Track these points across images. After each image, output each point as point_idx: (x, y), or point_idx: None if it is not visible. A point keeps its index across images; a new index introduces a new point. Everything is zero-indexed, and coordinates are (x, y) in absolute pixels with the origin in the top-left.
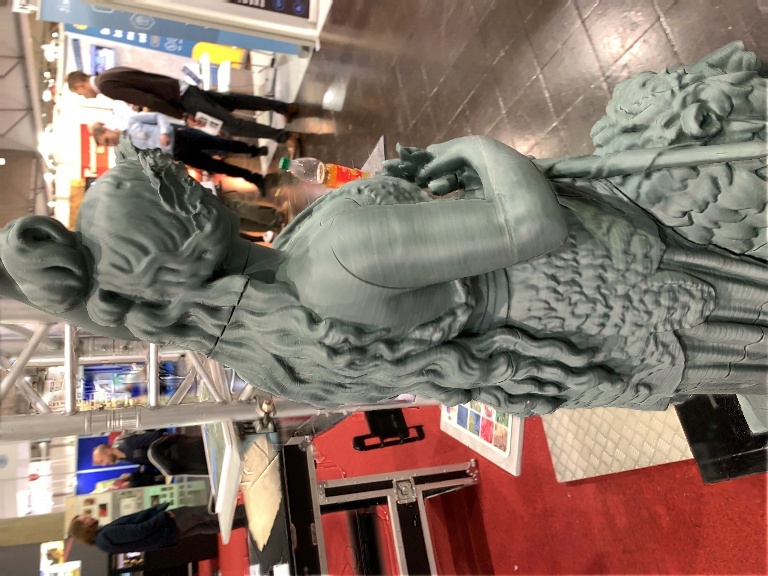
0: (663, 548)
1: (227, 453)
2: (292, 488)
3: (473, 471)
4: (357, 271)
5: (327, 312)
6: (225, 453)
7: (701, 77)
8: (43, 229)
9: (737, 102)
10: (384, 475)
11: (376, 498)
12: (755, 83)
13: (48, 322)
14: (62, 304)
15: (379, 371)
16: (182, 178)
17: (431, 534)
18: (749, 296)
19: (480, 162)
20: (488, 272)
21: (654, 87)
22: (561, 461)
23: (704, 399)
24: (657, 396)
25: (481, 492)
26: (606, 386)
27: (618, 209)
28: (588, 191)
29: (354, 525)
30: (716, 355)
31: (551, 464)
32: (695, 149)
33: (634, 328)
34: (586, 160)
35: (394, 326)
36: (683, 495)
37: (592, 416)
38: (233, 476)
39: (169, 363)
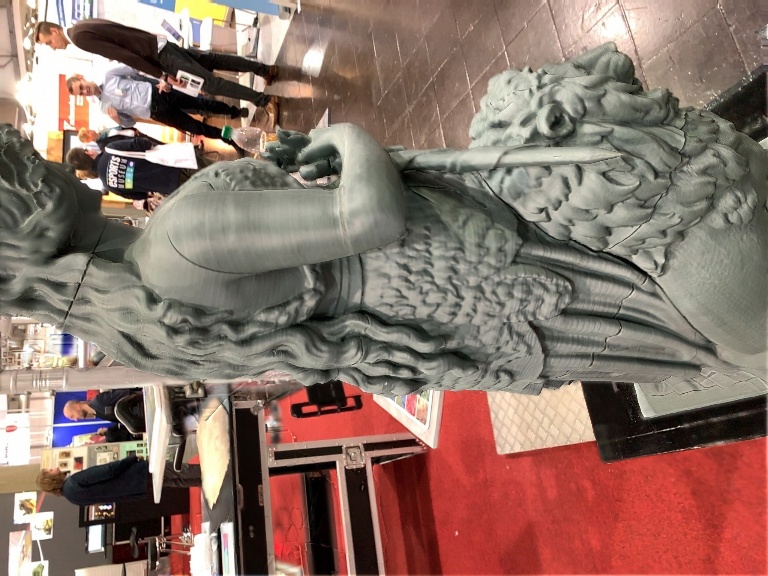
0: (587, 520)
1: (157, 416)
2: (242, 450)
3: None
4: (190, 255)
5: (166, 293)
6: (155, 416)
7: (559, 78)
8: None
9: (590, 105)
10: (334, 441)
11: (325, 463)
12: (609, 87)
13: None
14: None
15: (224, 350)
16: (25, 156)
17: (377, 499)
18: (608, 291)
19: (342, 151)
20: (343, 259)
21: (516, 85)
22: (502, 434)
23: (608, 383)
24: (523, 382)
25: (429, 460)
26: (458, 372)
27: (480, 202)
28: (454, 183)
29: (301, 488)
30: (576, 346)
31: (493, 437)
32: (536, 150)
33: (486, 318)
34: (444, 154)
35: (237, 308)
36: (608, 471)
37: None
38: (162, 438)
39: None
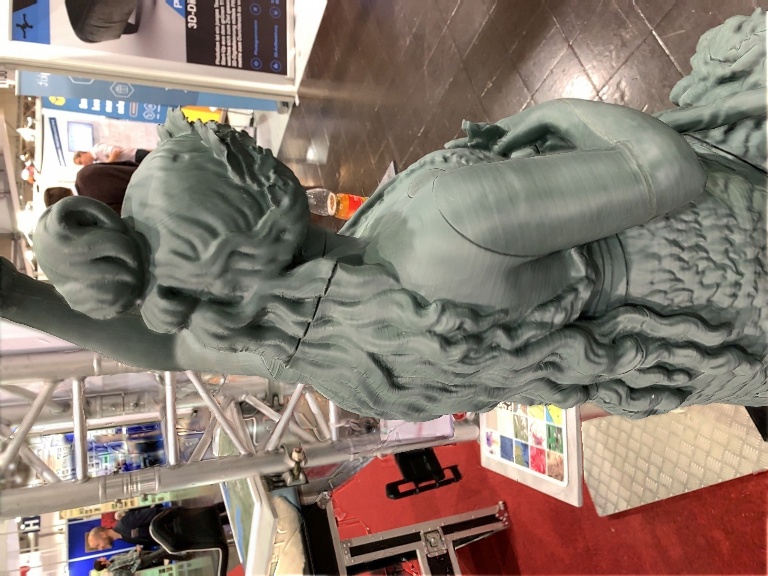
0: None
1: (256, 512)
2: (314, 550)
3: (502, 514)
4: (474, 236)
5: (436, 293)
6: (254, 512)
7: None
8: (88, 212)
9: None
10: (410, 527)
11: (404, 553)
12: None
13: (54, 379)
14: (113, 306)
15: (497, 364)
16: (249, 146)
17: None
18: None
19: (573, 122)
20: (600, 243)
21: (754, 27)
22: (600, 493)
23: None
24: None
25: (513, 537)
26: (744, 368)
27: (727, 166)
28: None
29: None
30: None
31: (589, 498)
32: None
33: (767, 297)
34: (694, 109)
35: (512, 307)
36: (742, 516)
37: (629, 441)
38: (265, 537)
39: (181, 420)
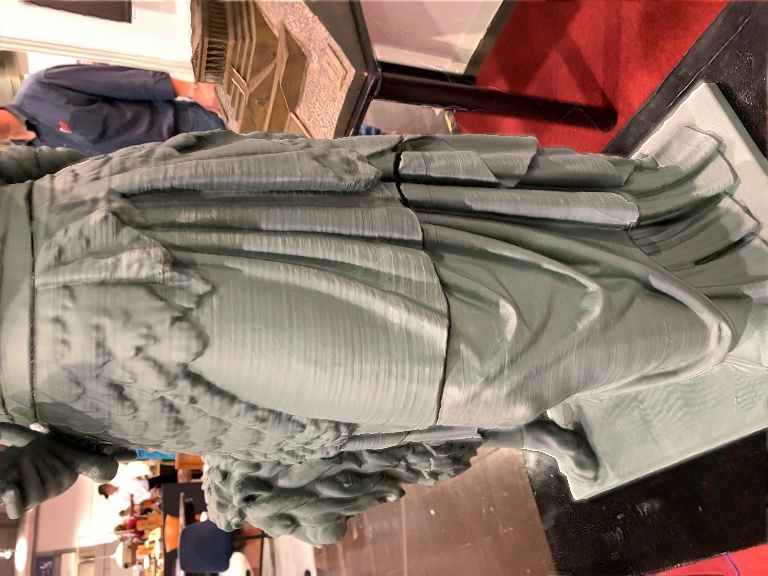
0: None
1: None
2: None
3: None
4: None
5: None
6: None
7: None
8: None
9: None
10: None
11: None
12: None
13: None
14: None
15: None
16: None
17: None
18: None
19: None
20: None
21: None
22: None
23: None
24: None
25: None
26: None
27: None
28: None
29: None
30: None
31: None
32: None
33: None
34: None
35: None
36: None
37: None
38: None
39: None
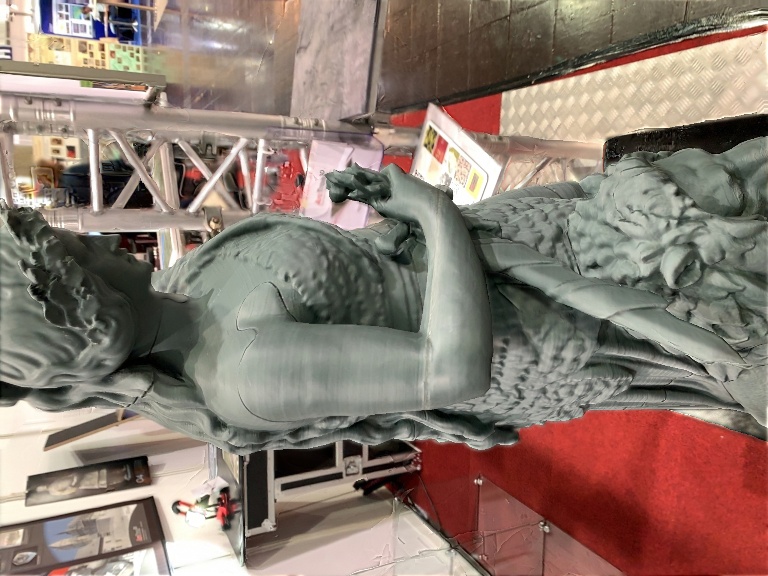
0: None
1: (173, 256)
2: None
3: None
4: (262, 415)
5: (232, 422)
6: (172, 255)
7: (707, 217)
8: None
9: (730, 257)
10: None
11: None
12: (761, 238)
13: None
14: None
15: None
16: (73, 289)
17: None
18: (666, 375)
19: (431, 252)
20: None
21: (653, 205)
22: None
23: None
24: None
25: None
26: None
27: None
28: None
29: None
30: None
31: None
32: (653, 324)
33: (540, 410)
34: (545, 276)
35: None
36: None
37: None
38: None
39: None
